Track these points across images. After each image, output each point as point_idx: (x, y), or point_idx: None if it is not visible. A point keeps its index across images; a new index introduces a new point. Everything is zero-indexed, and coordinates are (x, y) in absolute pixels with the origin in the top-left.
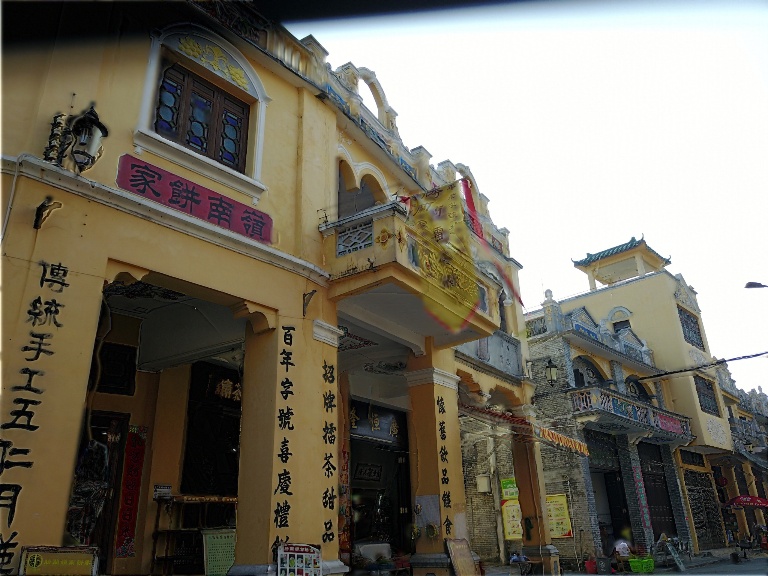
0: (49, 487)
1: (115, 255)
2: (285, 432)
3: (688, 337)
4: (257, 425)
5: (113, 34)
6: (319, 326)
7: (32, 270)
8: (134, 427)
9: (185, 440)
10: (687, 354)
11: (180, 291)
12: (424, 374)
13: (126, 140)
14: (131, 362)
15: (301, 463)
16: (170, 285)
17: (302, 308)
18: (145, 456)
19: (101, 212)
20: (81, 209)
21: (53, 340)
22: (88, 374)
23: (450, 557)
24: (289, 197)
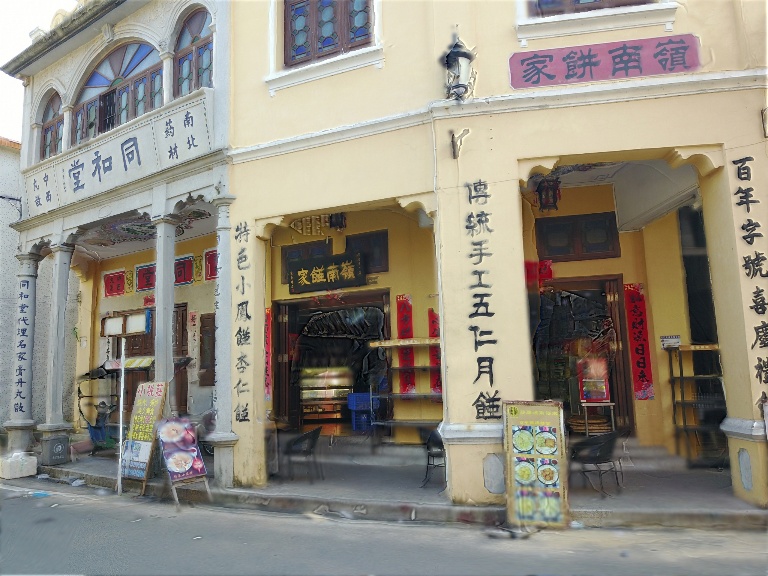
0: (513, 357)
1: (523, 155)
2: (756, 281)
3: None
4: (724, 276)
5: None
6: None
7: (461, 193)
8: (630, 285)
9: (686, 290)
10: None
11: (603, 161)
12: None
13: (511, 40)
14: (612, 226)
15: None
16: (588, 160)
17: (761, 129)
18: (646, 310)
19: (503, 121)
20: (486, 126)
21: (489, 244)
22: (523, 265)
23: None
24: None
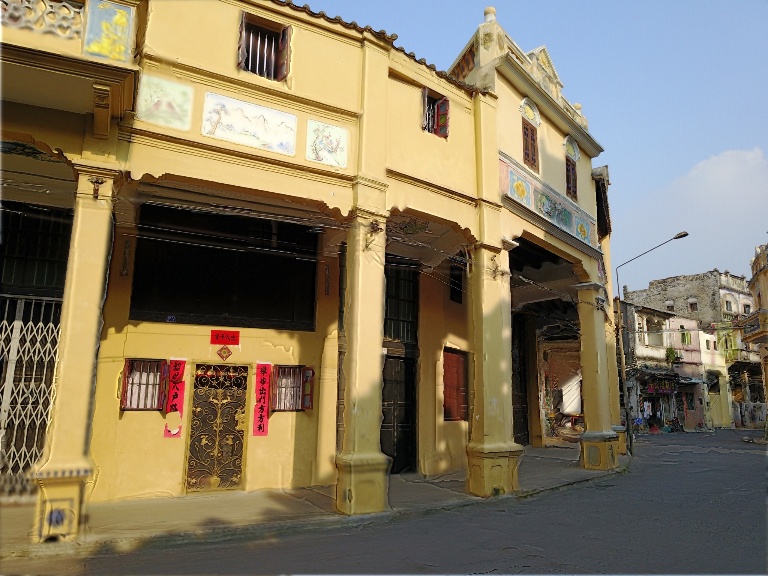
0: None
1: (762, 358)
2: None
3: None
4: None
5: None
6: None
7: None
8: None
9: None
10: None
11: None
12: None
13: None
14: None
15: None
16: None
17: None
18: None
19: None
20: None
21: None
22: None
23: None
24: None
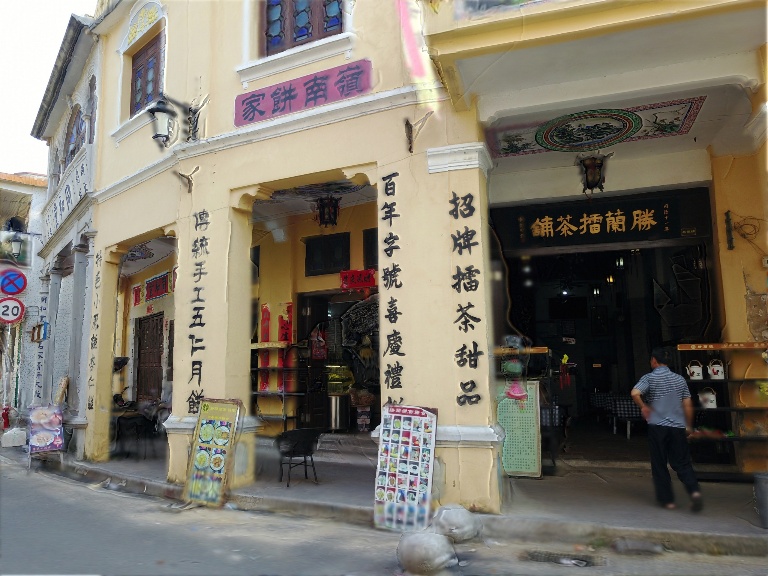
0: (214, 361)
1: (233, 185)
2: (392, 291)
3: None
4: None
5: (215, 4)
6: (435, 155)
7: (191, 222)
8: None
9: None
10: None
11: (308, 183)
12: (762, 120)
13: (236, 84)
14: None
15: (415, 321)
16: (292, 184)
17: (408, 144)
18: None
19: (223, 157)
20: (212, 162)
21: (206, 264)
22: (227, 281)
23: None
24: (391, 17)
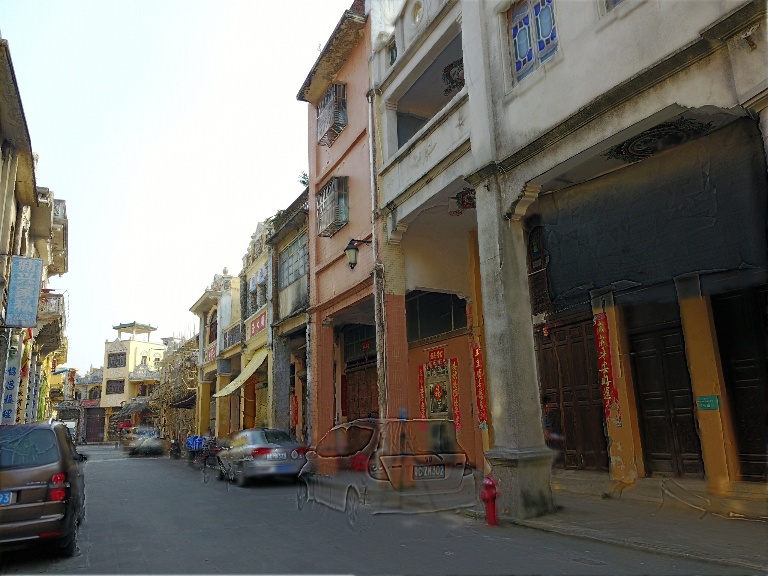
0: None
1: None
2: None
3: (115, 364)
4: None
5: None
6: None
7: None
8: None
9: None
10: (105, 374)
11: None
12: None
13: None
14: None
15: None
16: None
17: None
18: None
19: None
20: None
21: None
22: None
23: None
24: None
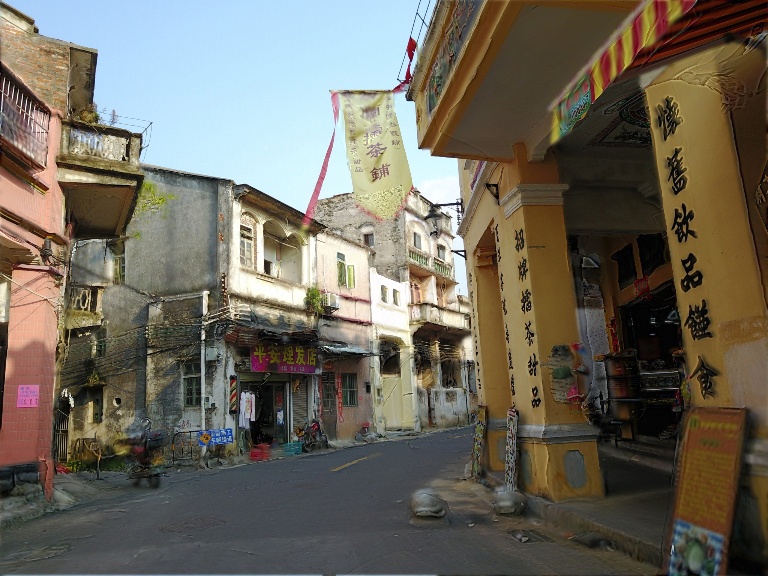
0: None
1: None
2: None
3: None
4: None
5: None
6: (504, 204)
7: None
8: None
9: None
10: None
11: None
12: None
13: None
14: None
15: None
16: None
17: None
18: None
19: None
20: None
21: None
22: None
23: (677, 445)
24: None
